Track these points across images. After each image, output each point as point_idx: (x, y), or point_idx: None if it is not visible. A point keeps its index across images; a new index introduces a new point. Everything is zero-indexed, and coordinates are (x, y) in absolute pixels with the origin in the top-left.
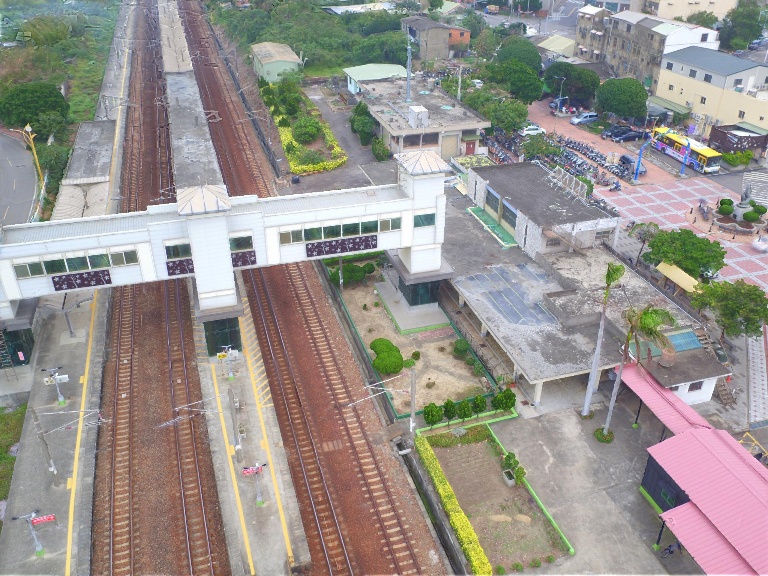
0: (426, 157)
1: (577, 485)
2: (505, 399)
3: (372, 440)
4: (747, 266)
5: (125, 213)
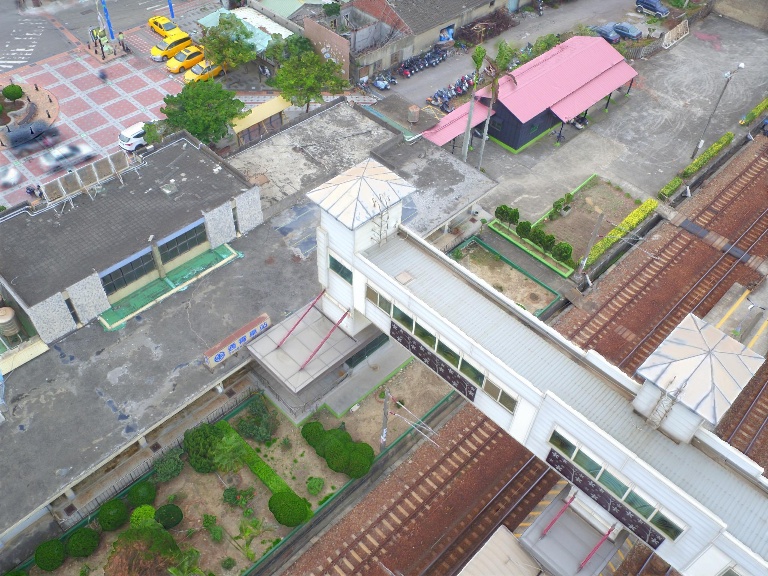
0: (372, 175)
1: (538, 181)
2: (512, 209)
3: (594, 309)
4: (122, 110)
5: (764, 562)
